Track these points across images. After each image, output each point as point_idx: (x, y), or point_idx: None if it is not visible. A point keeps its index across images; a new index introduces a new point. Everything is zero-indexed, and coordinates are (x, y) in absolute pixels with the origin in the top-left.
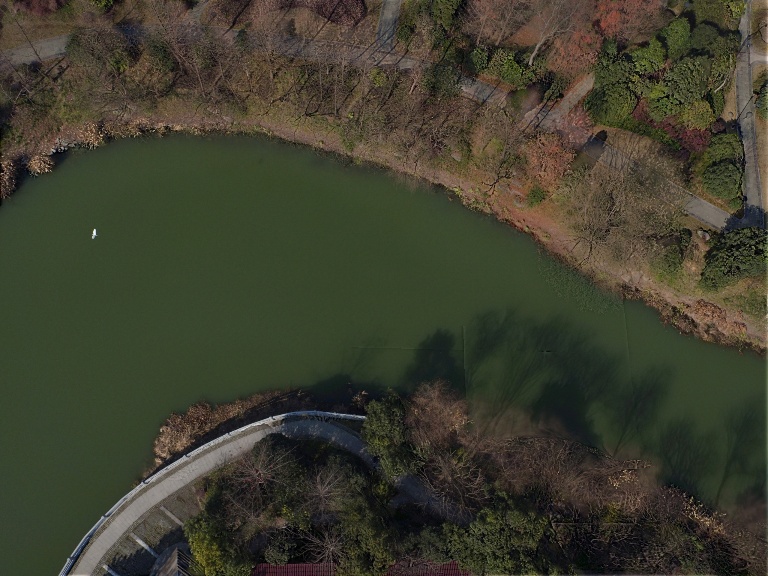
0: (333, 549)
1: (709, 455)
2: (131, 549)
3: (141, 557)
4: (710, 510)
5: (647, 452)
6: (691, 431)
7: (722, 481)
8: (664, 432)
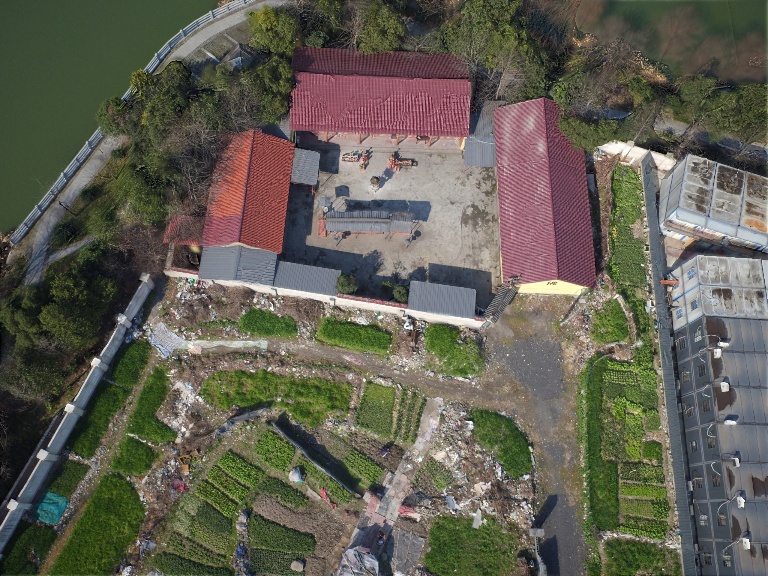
0: (357, 33)
1: (655, 33)
2: (202, 58)
3: (210, 63)
4: (654, 62)
5: (605, 29)
6: (641, 17)
7: (665, 50)
8: (620, 17)
